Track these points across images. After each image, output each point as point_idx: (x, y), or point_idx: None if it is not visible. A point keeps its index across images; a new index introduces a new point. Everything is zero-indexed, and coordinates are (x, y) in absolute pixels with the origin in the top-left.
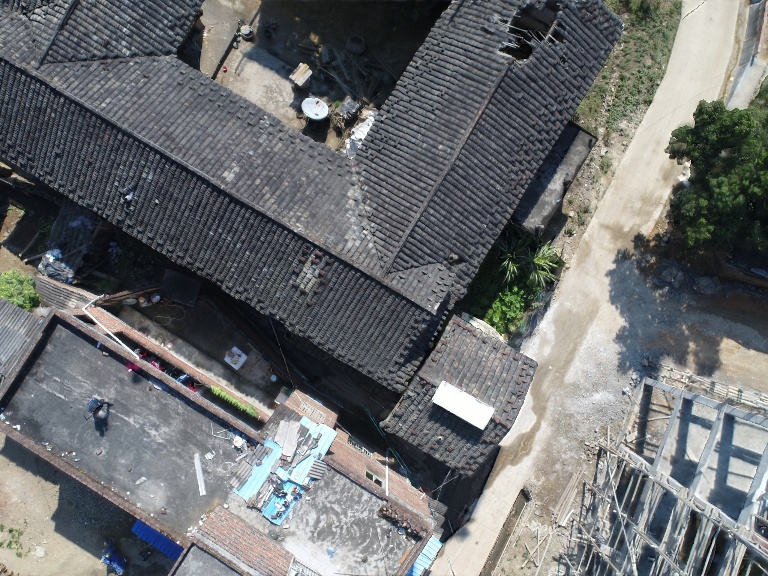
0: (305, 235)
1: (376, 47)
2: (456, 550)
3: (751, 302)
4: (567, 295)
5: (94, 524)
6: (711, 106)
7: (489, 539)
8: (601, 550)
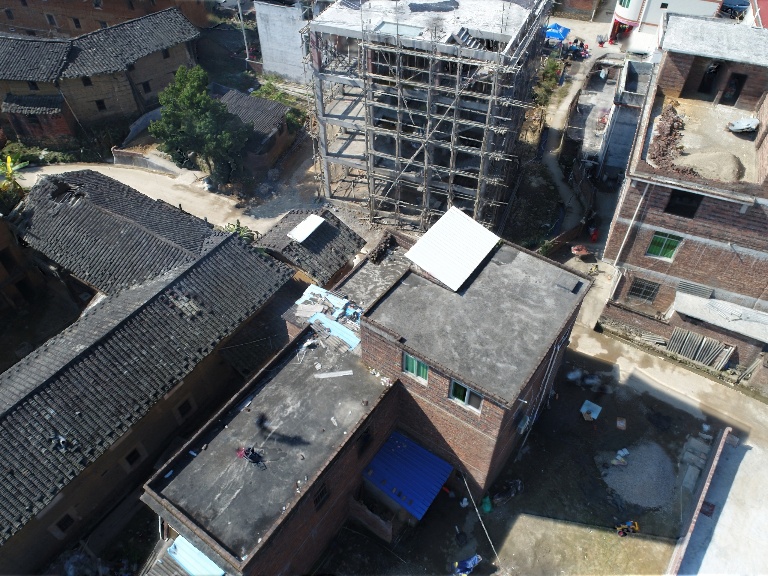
0: (151, 297)
1: (34, 340)
2: None
3: (289, 160)
4: None
5: None
6: (153, 126)
7: None
8: (421, 190)
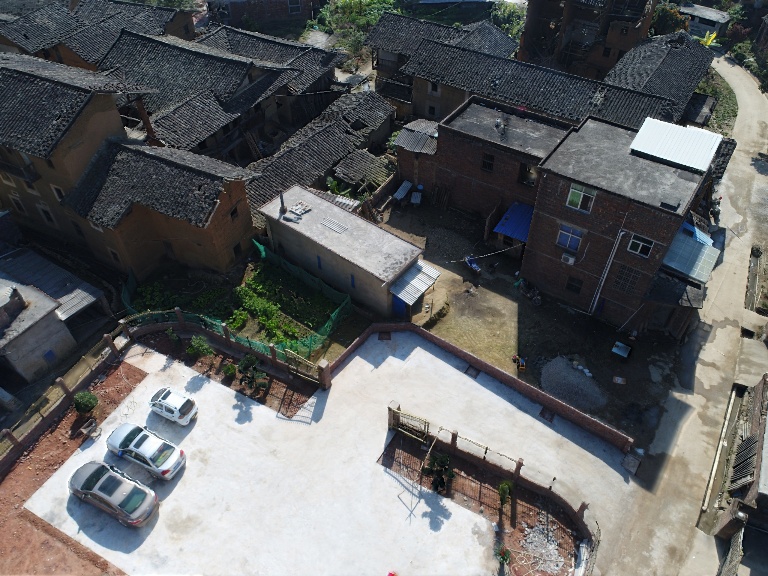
0: None
1: None
2: (721, 277)
3: None
4: (731, 171)
5: (451, 257)
6: None
7: (743, 271)
8: None
